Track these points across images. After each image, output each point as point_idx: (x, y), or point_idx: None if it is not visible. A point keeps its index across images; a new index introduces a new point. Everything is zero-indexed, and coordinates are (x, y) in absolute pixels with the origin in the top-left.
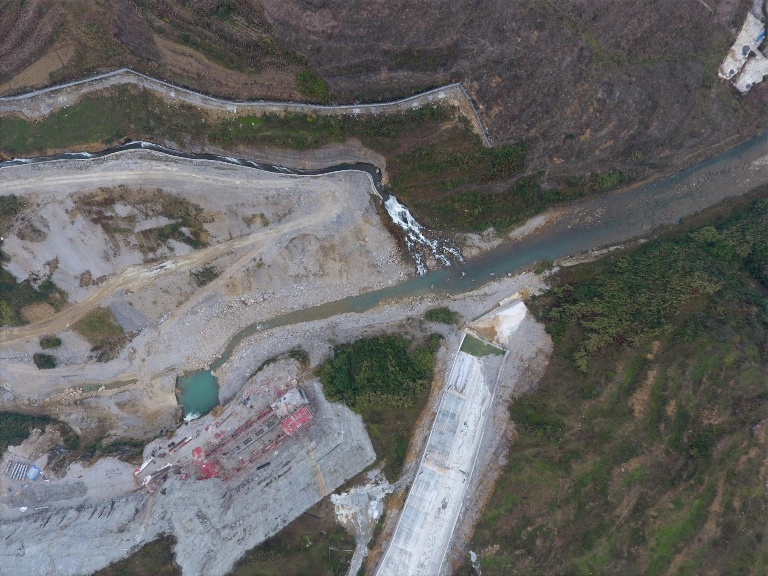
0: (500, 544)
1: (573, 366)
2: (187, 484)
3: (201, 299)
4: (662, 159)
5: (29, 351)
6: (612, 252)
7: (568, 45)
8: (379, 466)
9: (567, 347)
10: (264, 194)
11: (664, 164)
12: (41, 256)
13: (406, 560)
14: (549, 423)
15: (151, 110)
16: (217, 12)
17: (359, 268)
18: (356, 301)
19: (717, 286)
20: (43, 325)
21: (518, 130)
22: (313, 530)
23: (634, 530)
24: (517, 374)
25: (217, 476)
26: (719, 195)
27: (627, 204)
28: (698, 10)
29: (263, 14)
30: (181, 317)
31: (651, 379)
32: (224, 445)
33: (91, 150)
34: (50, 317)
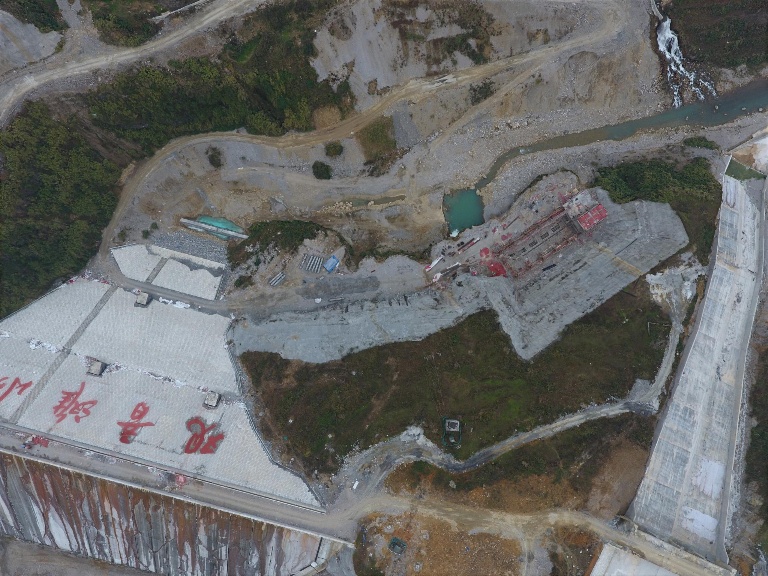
0: None
1: None
2: (483, 277)
3: (473, 117)
4: None
5: (310, 158)
6: None
7: None
8: (691, 249)
9: None
10: (554, 7)
11: None
12: (342, 56)
13: (711, 345)
14: None
15: None
16: None
17: (625, 93)
18: (614, 130)
19: None
20: (328, 132)
21: None
22: (630, 307)
23: None
24: None
25: (505, 275)
26: None
27: None
28: None
29: None
30: (451, 136)
31: None
32: (518, 241)
33: None
34: (335, 124)
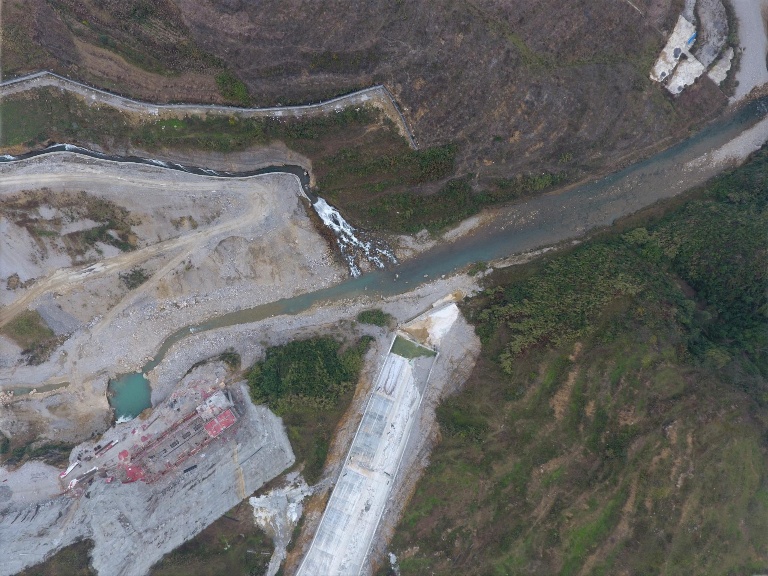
0: (420, 546)
1: (499, 367)
2: (111, 487)
3: (132, 302)
4: (594, 161)
5: None
6: (545, 254)
7: (494, 48)
8: (298, 468)
9: (494, 349)
10: (191, 197)
11: (597, 166)
12: None
13: (327, 562)
14: (474, 425)
15: (73, 113)
16: (134, 15)
17: (291, 270)
18: (290, 303)
19: (639, 287)
20: None
21: (445, 132)
22: (232, 533)
23: (550, 531)
24: (446, 376)
25: (143, 479)
26: (652, 197)
27: (561, 206)
28: (628, 13)
29: (180, 17)
30: (112, 320)
31: (572, 380)
32: (149, 448)
33: (13, 153)
34: None
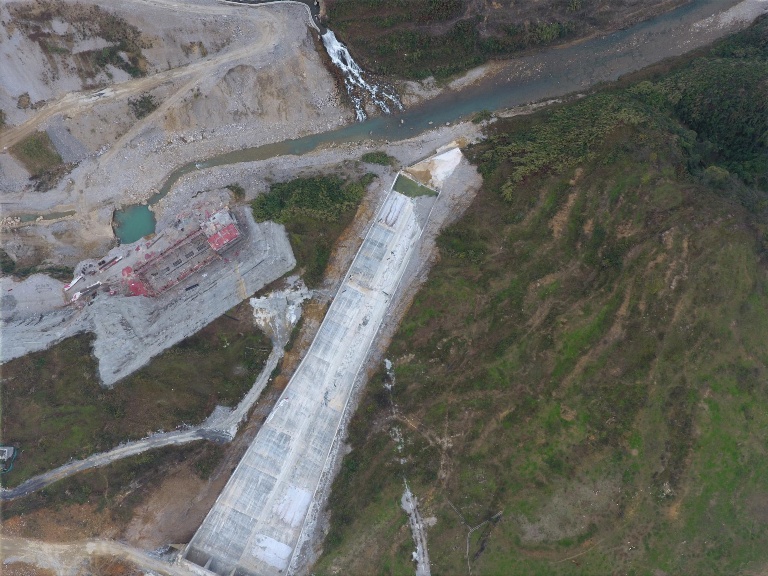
0: (415, 354)
1: (500, 198)
2: (114, 297)
3: (140, 132)
4: (602, 15)
5: None
6: (550, 105)
7: None
8: (299, 273)
9: (496, 183)
10: (202, 19)
11: (605, 21)
12: None
13: (323, 369)
14: (473, 249)
15: None
16: None
17: (297, 107)
18: (295, 144)
19: (642, 118)
20: None
21: None
22: (231, 331)
23: (544, 336)
24: (447, 211)
25: (146, 295)
26: (658, 55)
27: (567, 60)
28: None
29: None
30: (120, 150)
31: (571, 201)
32: (152, 261)
33: None
34: None
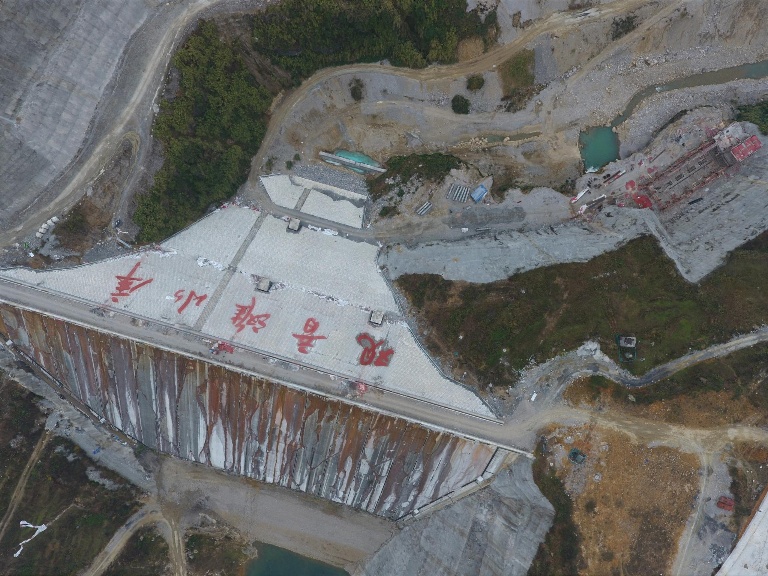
0: None
1: None
2: (633, 208)
3: (613, 53)
4: None
5: (451, 92)
6: None
7: None
8: None
9: None
10: None
11: None
12: None
13: None
14: None
15: None
16: None
17: None
18: (752, 69)
19: None
20: (470, 65)
21: None
22: None
23: None
24: None
25: (651, 208)
26: None
27: None
28: None
29: None
30: (589, 72)
31: None
32: (668, 173)
33: None
34: (477, 57)
